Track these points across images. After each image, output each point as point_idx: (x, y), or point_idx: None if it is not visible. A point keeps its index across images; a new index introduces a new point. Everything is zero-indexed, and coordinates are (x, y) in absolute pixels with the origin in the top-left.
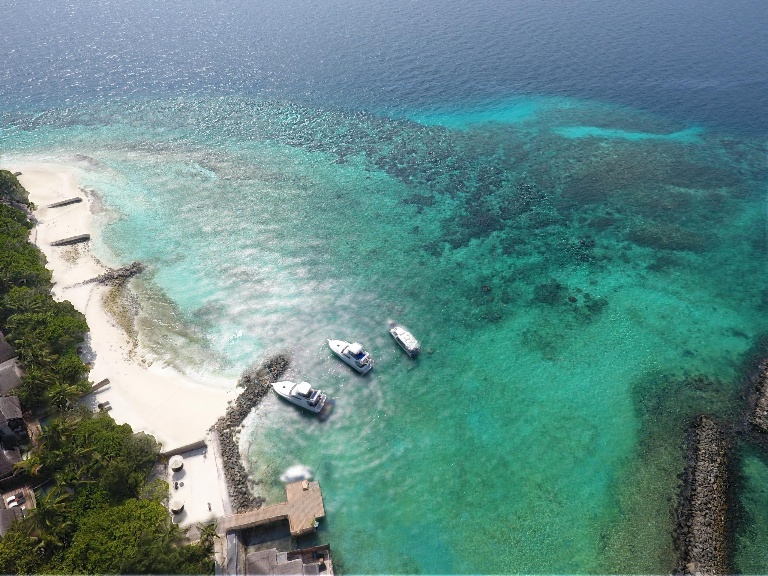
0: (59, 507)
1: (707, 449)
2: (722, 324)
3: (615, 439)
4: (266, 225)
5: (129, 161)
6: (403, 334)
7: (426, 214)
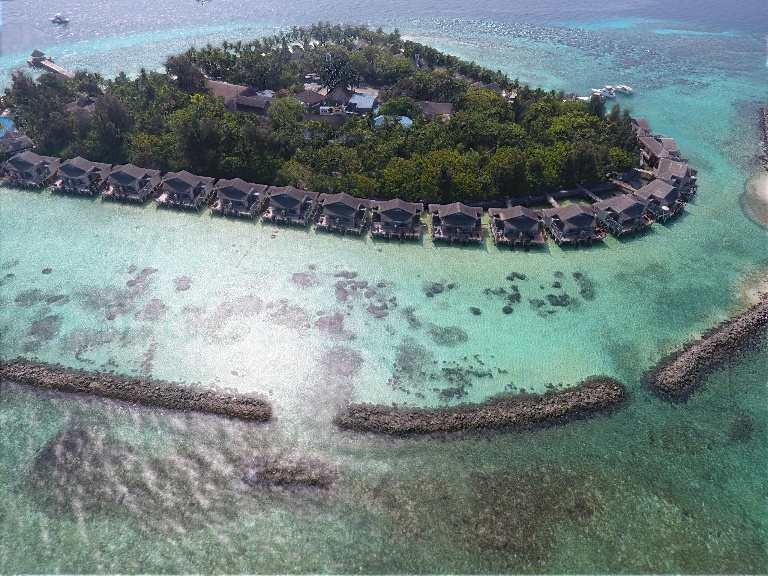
0: (552, 97)
1: (767, 112)
2: (767, 90)
3: (728, 113)
4: (522, 61)
5: (422, 40)
6: (624, 86)
7: (601, 59)
